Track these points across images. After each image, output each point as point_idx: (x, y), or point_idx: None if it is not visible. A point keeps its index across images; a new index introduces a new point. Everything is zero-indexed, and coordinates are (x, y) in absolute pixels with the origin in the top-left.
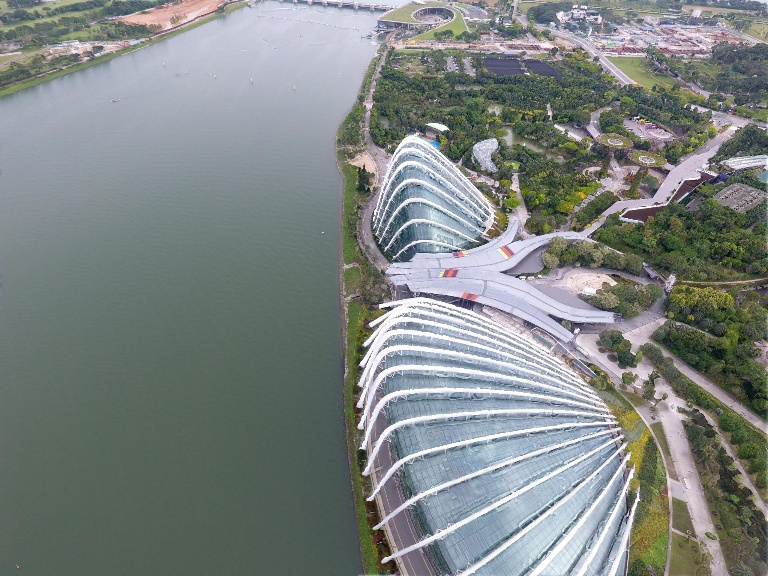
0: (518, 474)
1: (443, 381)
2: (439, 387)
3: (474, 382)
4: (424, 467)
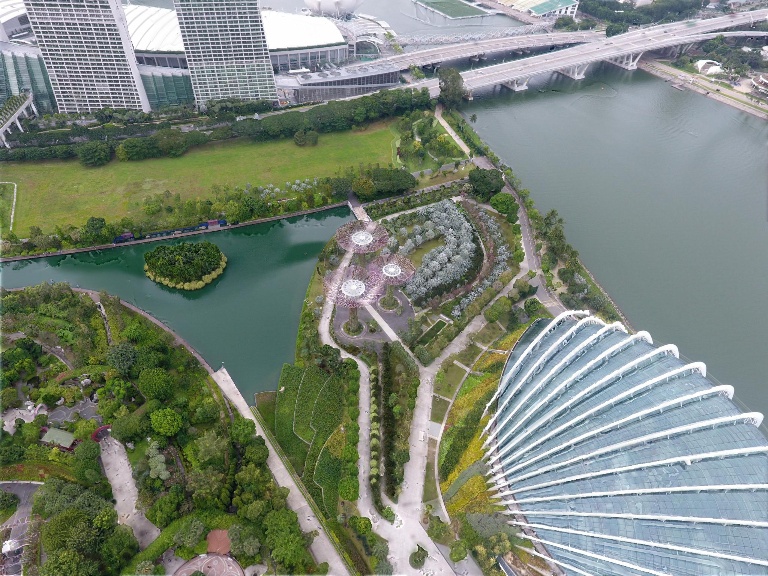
0: (619, 389)
1: (733, 476)
2: (734, 466)
3: (693, 481)
4: (708, 385)
